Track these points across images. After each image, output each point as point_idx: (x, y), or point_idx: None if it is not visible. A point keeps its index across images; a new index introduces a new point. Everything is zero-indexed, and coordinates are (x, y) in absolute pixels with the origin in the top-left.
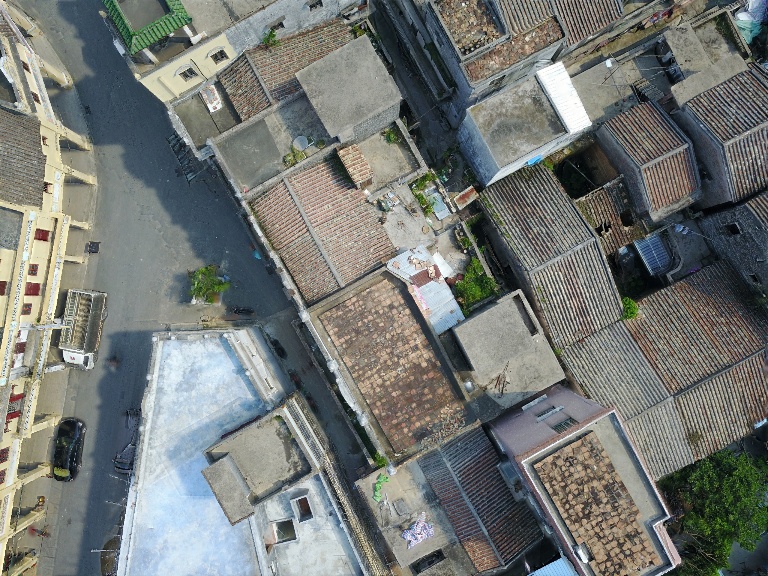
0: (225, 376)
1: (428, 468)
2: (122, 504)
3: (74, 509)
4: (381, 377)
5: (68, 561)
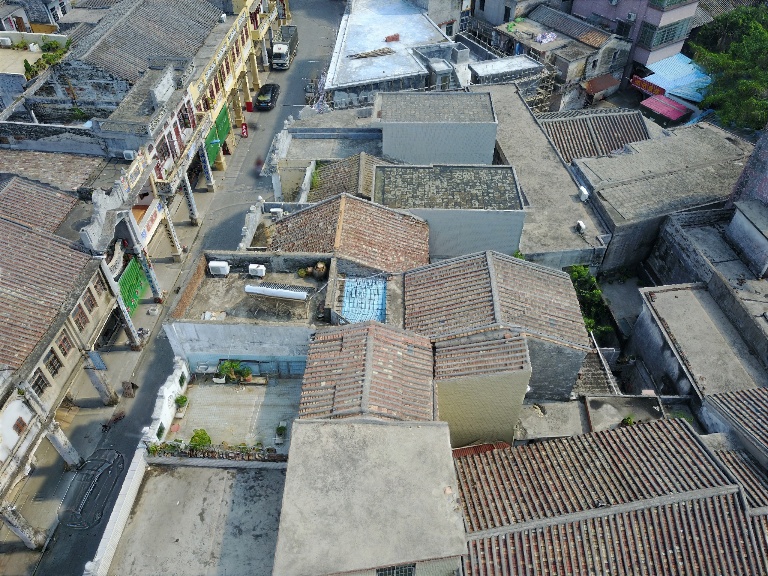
0: None
1: (540, 18)
2: None
3: (268, 124)
4: None
5: (261, 147)
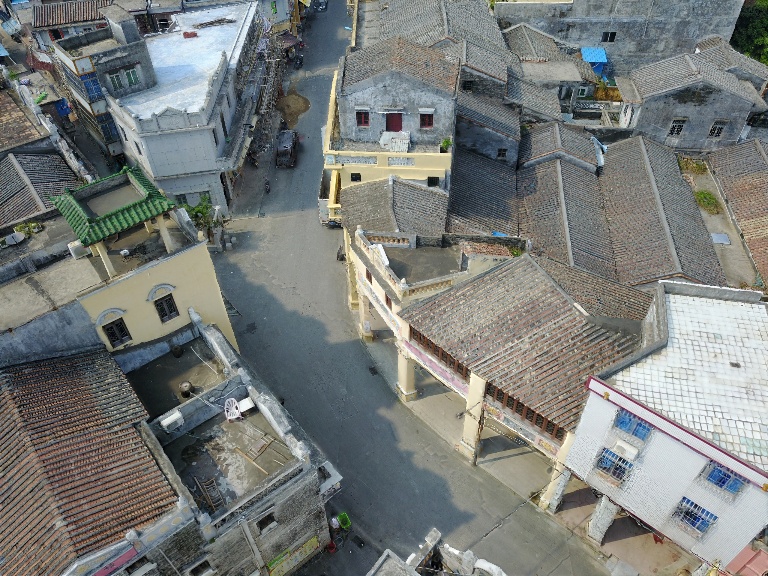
0: (149, 112)
1: None
2: (297, 127)
3: None
4: (0, 120)
5: None
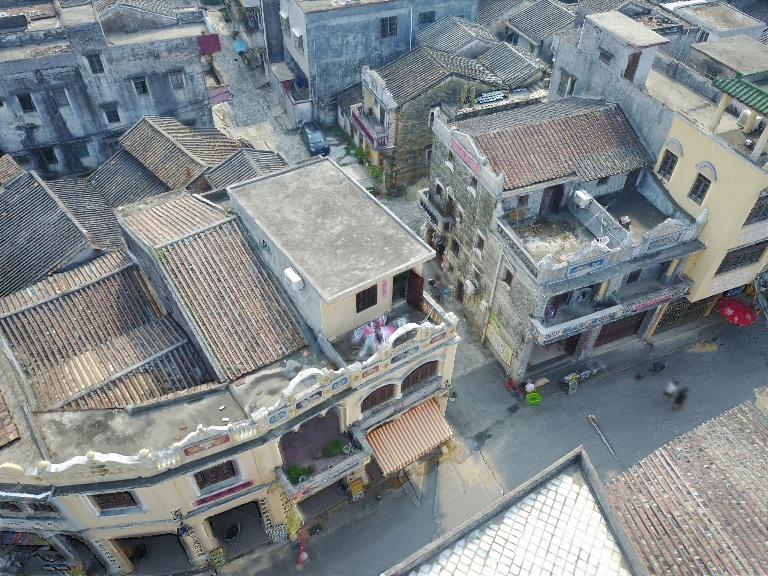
0: None
1: None
2: None
3: None
4: None
5: None
